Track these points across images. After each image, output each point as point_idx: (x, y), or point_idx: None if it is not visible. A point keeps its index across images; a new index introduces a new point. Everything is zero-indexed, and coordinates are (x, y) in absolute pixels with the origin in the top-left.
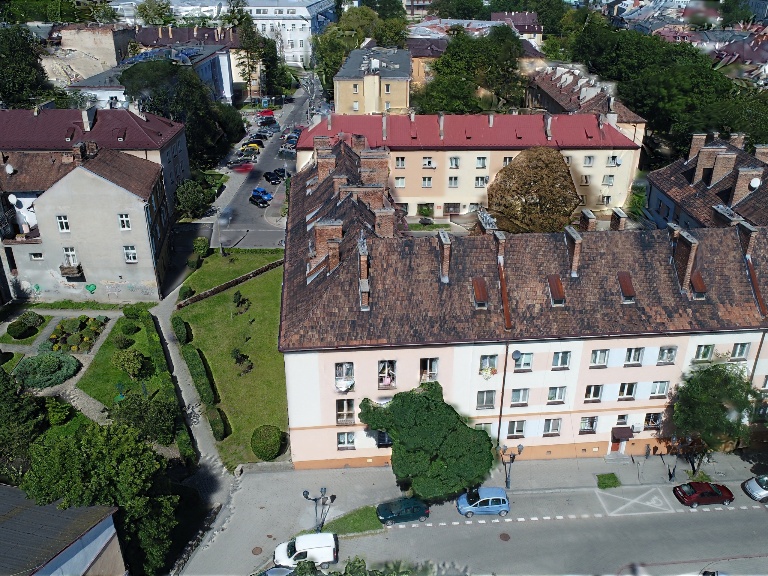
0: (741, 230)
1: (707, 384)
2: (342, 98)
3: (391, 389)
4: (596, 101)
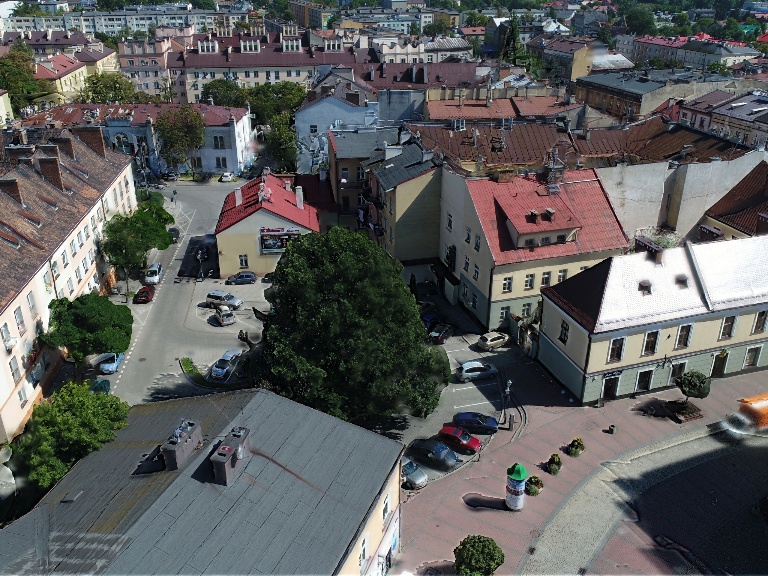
0: (45, 150)
1: (120, 230)
2: None
3: (25, 333)
4: None
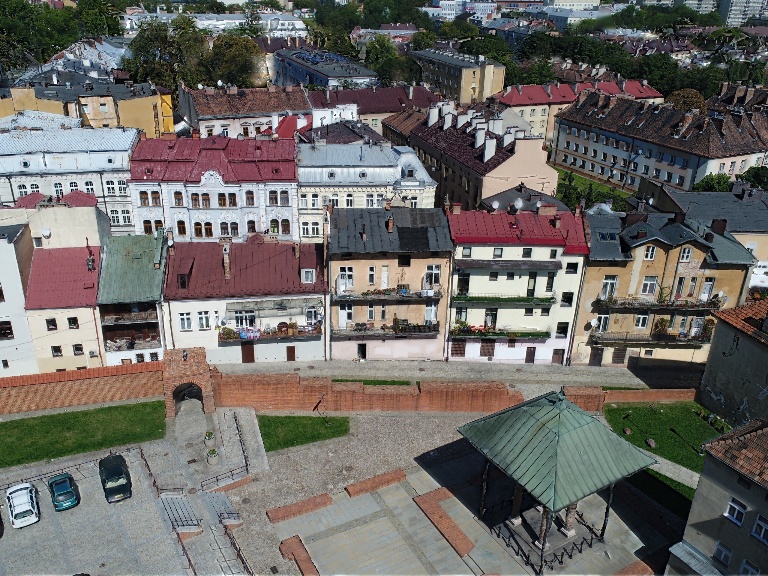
0: None
1: None
2: (466, 81)
3: None
4: (607, 76)
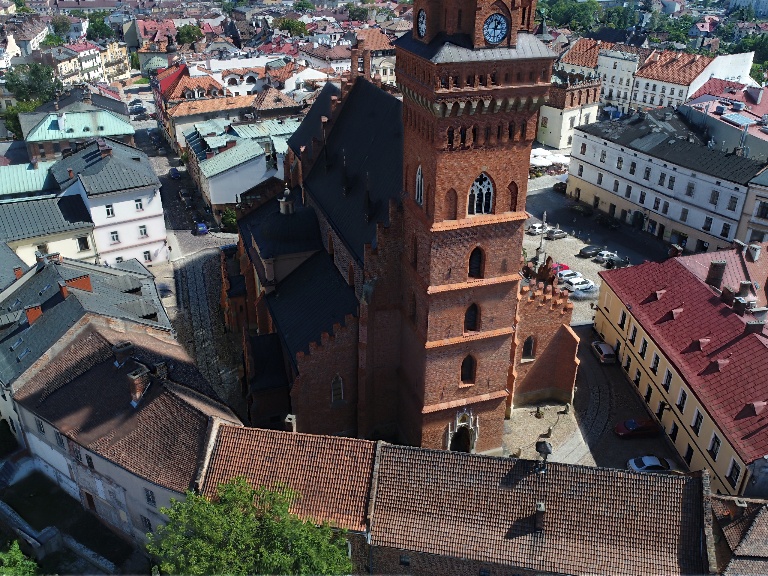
0: None
1: None
2: None
3: None
4: None
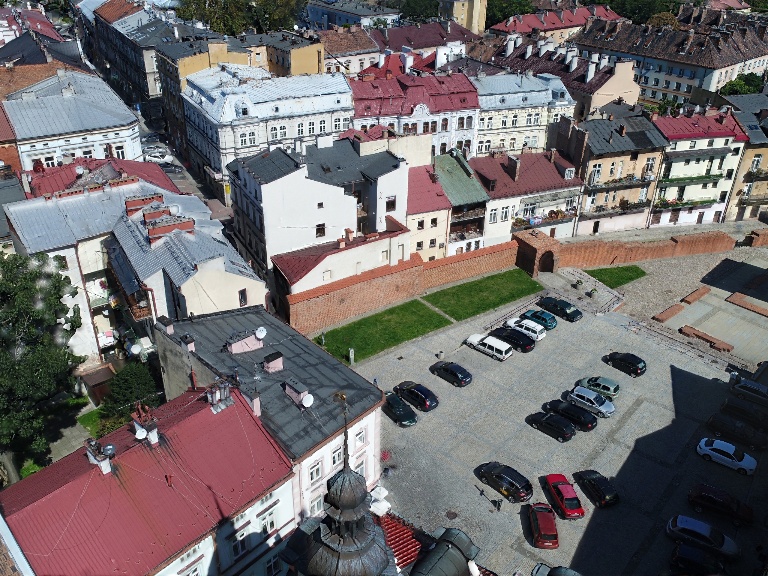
0: (763, 24)
1: None
2: (457, 13)
3: None
4: (567, 3)
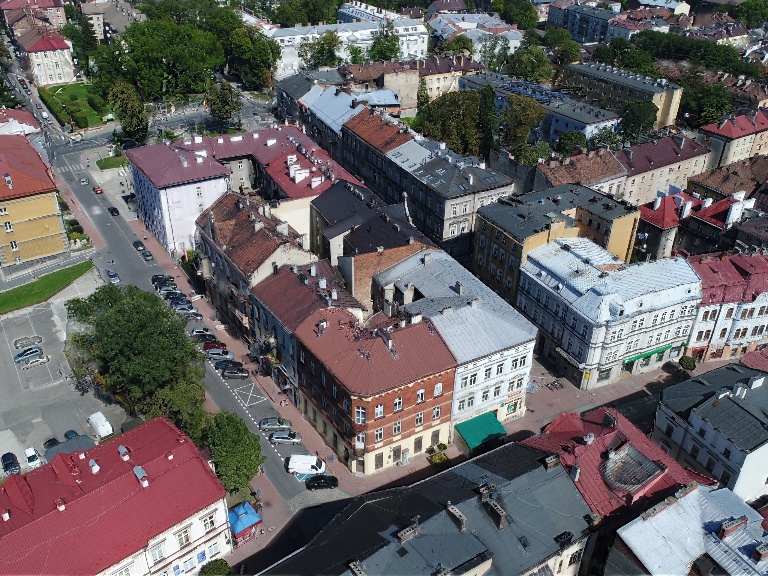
0: None
1: None
2: None
3: None
4: (755, 88)
